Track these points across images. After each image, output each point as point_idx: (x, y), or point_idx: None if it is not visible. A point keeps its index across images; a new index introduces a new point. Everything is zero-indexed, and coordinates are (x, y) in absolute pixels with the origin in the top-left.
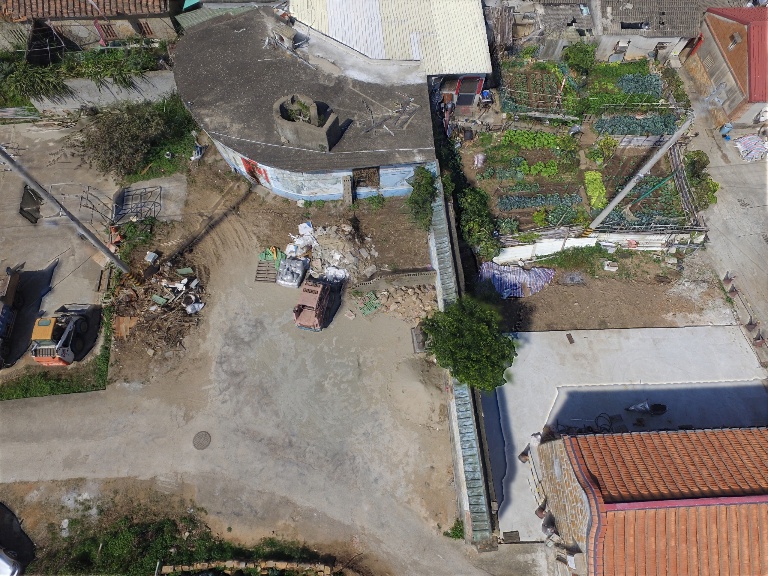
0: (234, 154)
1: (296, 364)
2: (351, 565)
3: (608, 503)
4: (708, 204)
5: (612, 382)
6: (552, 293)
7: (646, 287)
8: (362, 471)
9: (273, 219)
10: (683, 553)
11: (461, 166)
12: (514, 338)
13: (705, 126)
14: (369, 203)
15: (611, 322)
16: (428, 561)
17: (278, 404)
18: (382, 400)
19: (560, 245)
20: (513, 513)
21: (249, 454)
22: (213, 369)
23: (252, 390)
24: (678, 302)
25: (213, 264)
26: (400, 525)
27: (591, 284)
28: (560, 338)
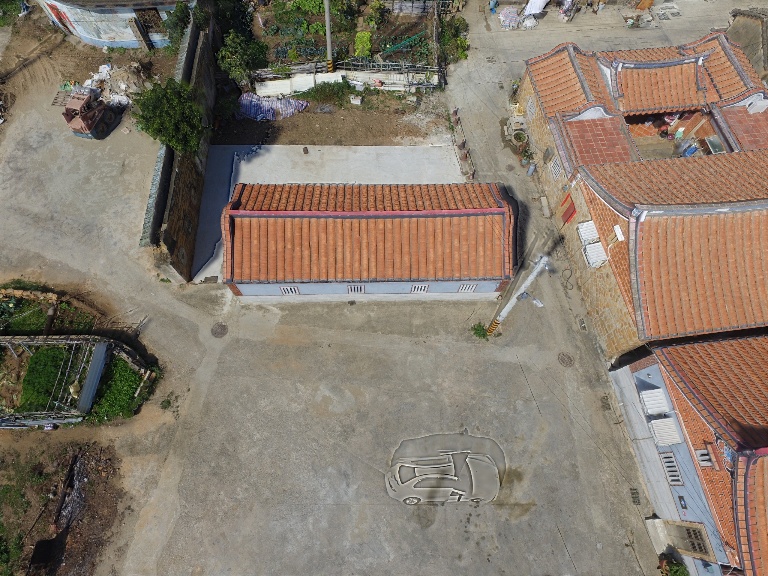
0: (41, 1)
1: (71, 164)
2: (78, 297)
3: (234, 210)
4: (456, 57)
5: (331, 182)
6: (299, 118)
7: (381, 116)
8: (106, 237)
9: (79, 61)
10: (297, 255)
11: (251, 25)
12: (258, 149)
13: (480, 3)
14: (165, 51)
15: (346, 141)
16: (142, 297)
17: (49, 191)
18: (136, 190)
19: (312, 80)
20: (218, 265)
21: (16, 224)
22: (1, 166)
23: (30, 181)
24: (405, 127)
25: (20, 93)
26: (126, 273)
27: (336, 113)
28: (297, 150)
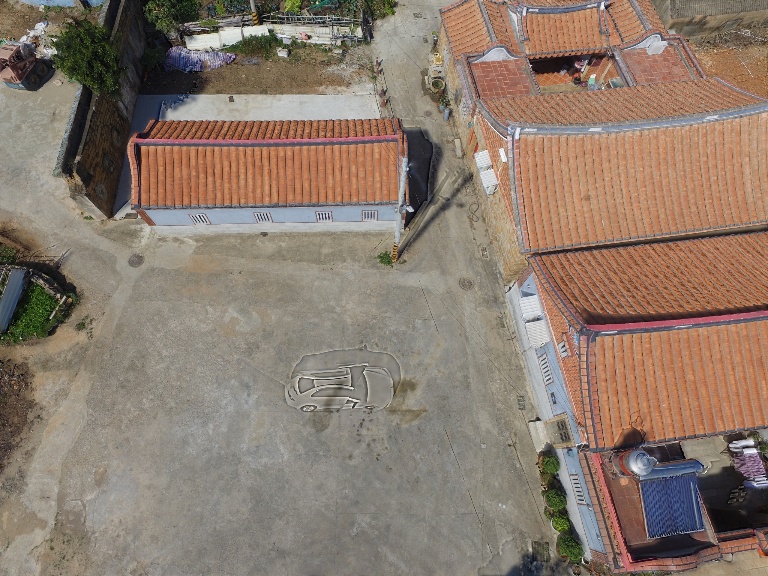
0: None
1: (3, 113)
2: (3, 234)
3: (139, 138)
4: (382, 13)
5: None
6: (227, 69)
7: (306, 67)
8: (33, 180)
9: (16, 19)
10: (202, 181)
11: None
12: (185, 98)
13: None
14: (100, 10)
15: (272, 91)
16: (65, 233)
17: None
18: None
19: (240, 34)
20: None
21: None
22: None
23: None
24: (329, 77)
25: None
26: (51, 212)
27: (263, 65)
28: (223, 99)
